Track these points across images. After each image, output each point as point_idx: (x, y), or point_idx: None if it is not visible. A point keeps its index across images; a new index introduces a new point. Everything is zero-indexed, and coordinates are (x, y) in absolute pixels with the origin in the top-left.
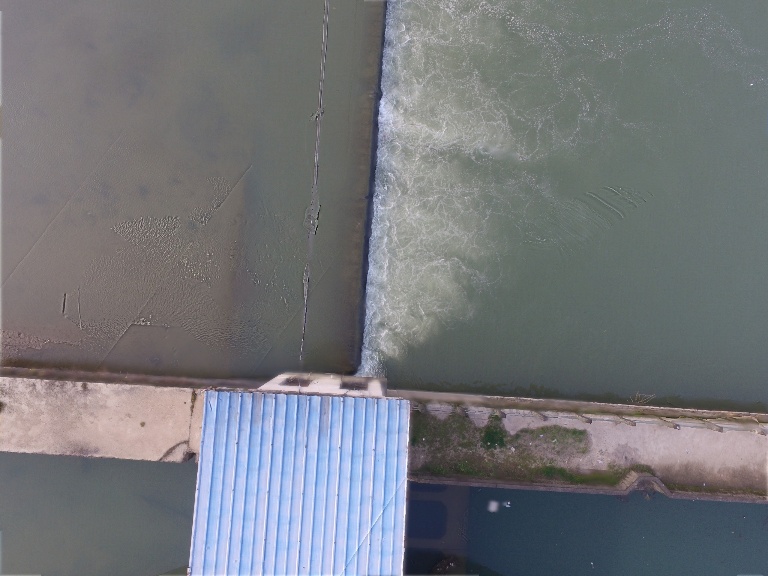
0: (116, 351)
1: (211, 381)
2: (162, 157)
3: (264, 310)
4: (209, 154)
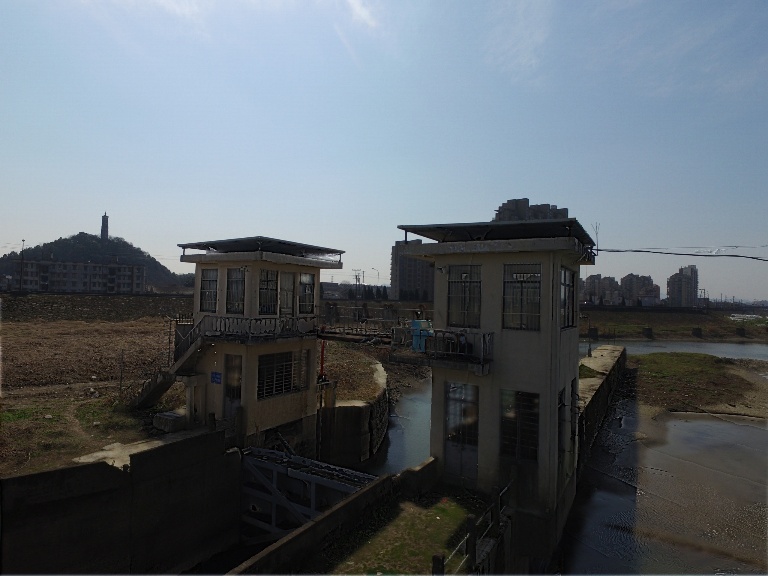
0: (606, 476)
1: None
2: None
3: (670, 567)
4: None
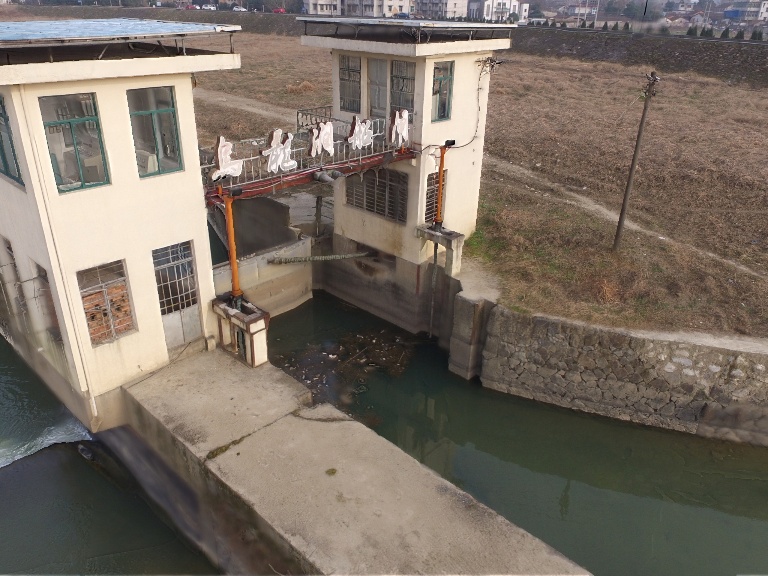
0: None
1: (216, 547)
2: None
3: None
4: None
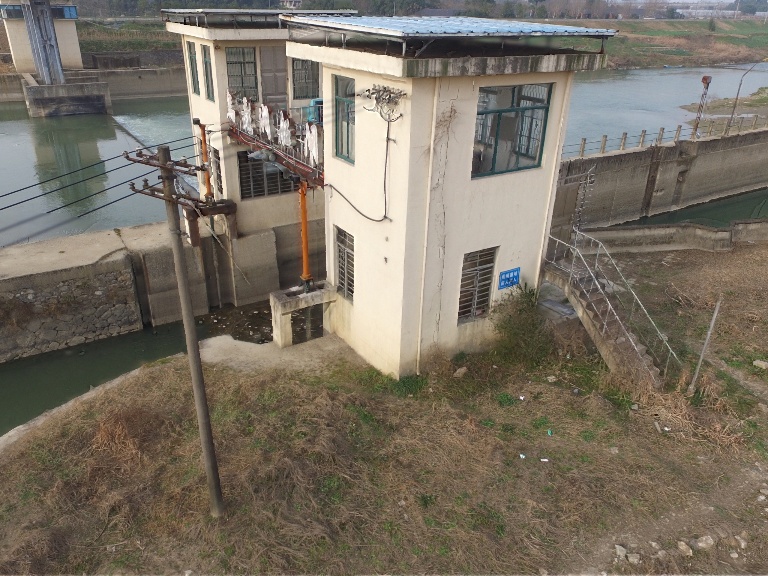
0: None
1: None
2: (3, 233)
3: None
4: (53, 225)
